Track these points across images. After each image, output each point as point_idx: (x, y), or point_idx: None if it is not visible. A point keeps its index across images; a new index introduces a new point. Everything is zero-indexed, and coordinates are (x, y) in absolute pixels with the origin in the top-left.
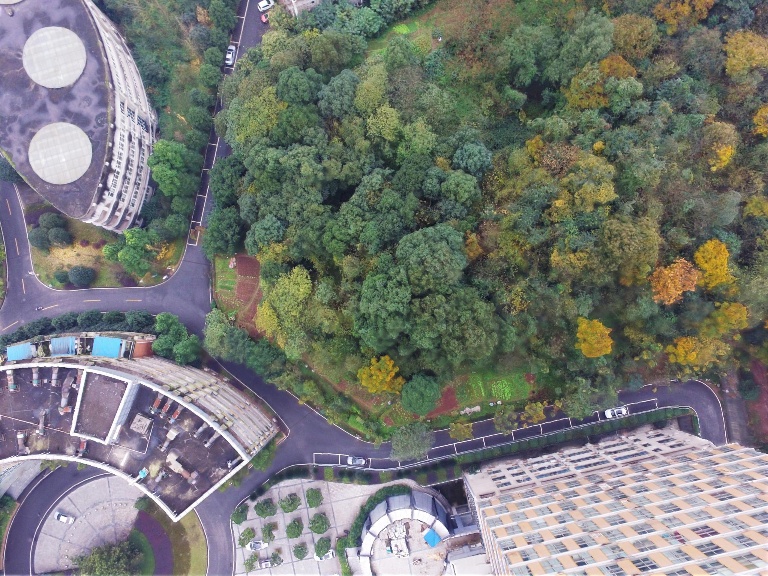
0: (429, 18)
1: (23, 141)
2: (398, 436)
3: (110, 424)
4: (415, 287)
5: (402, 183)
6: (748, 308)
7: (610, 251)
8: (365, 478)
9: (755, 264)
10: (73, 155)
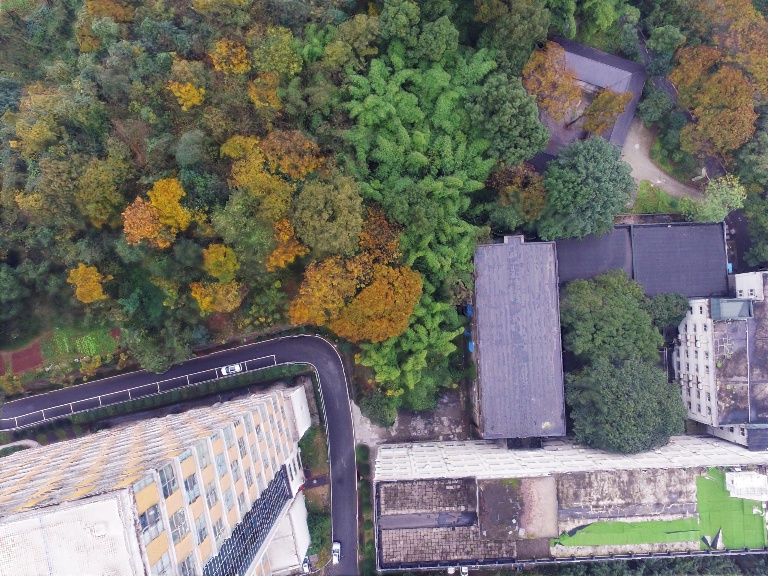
0: None
1: None
2: None
3: None
4: None
5: None
6: (241, 250)
7: None
8: None
9: None
10: None
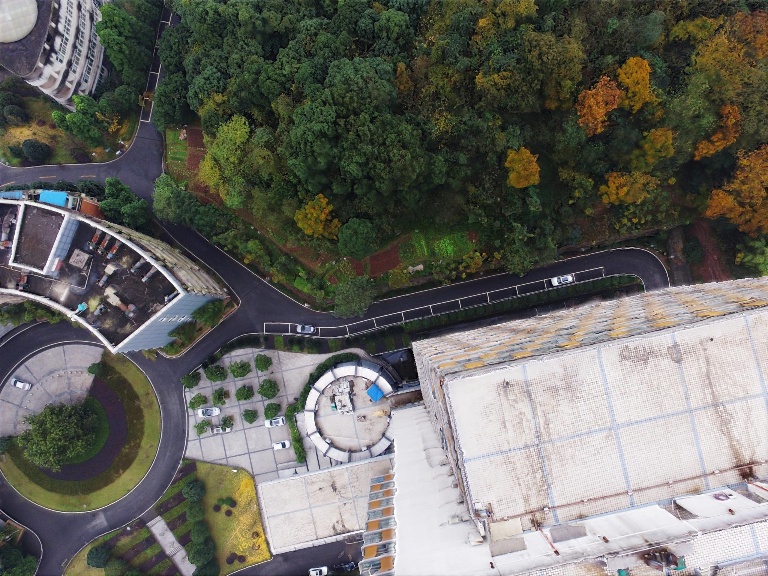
0: None
1: None
2: (339, 289)
3: (48, 255)
4: (340, 107)
5: (337, 26)
6: (676, 137)
7: (531, 66)
8: (314, 345)
9: (681, 88)
10: (19, 14)
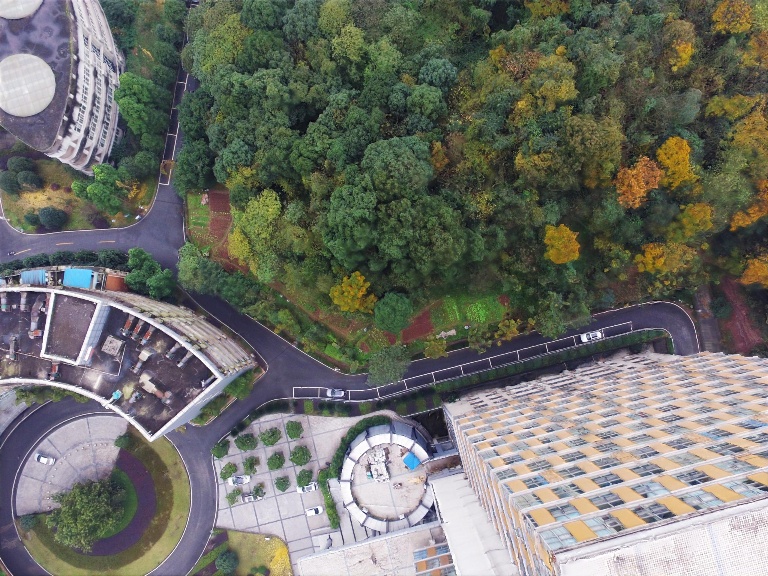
0: None
1: None
2: (374, 359)
3: (80, 345)
4: (380, 192)
5: (368, 100)
6: (713, 210)
7: (573, 149)
8: (345, 409)
9: (718, 163)
10: (36, 87)
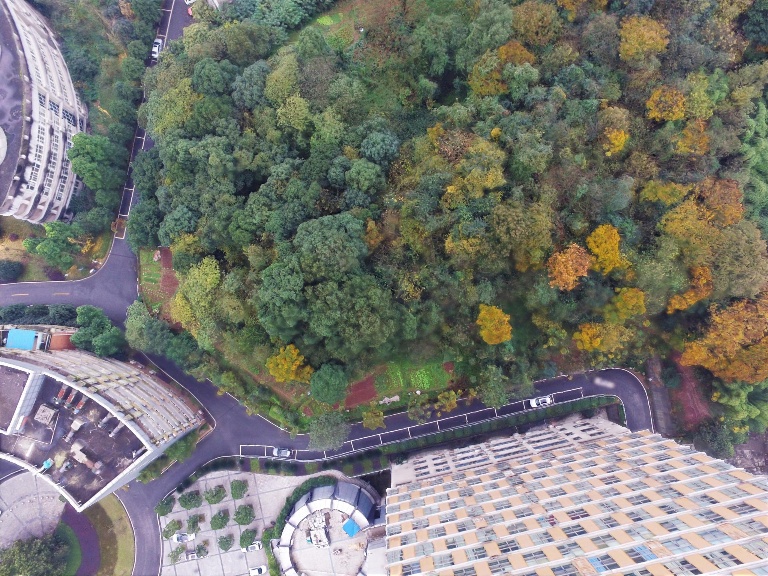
0: (352, 9)
1: None
2: (314, 426)
3: (12, 415)
4: (308, 274)
5: (308, 172)
6: (648, 293)
7: (500, 236)
8: (290, 469)
9: (651, 249)
10: None
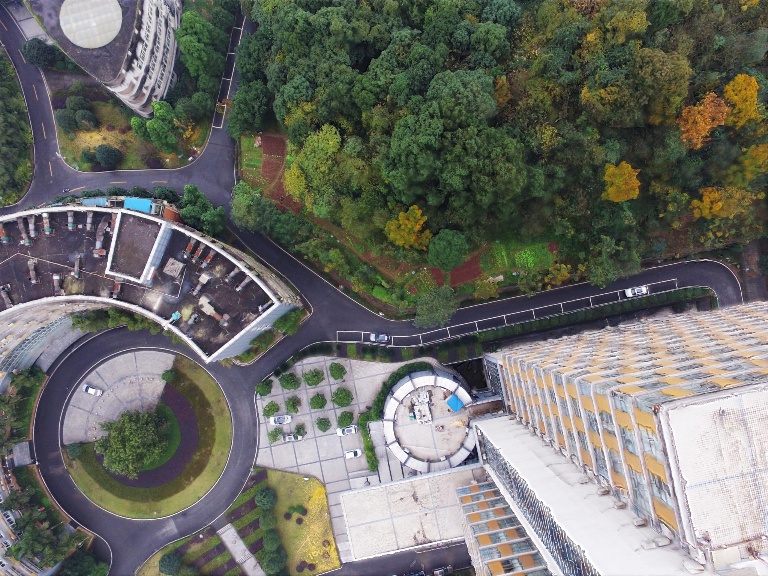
0: None
1: (54, 5)
2: (423, 299)
3: (144, 263)
4: (447, 120)
5: (431, 37)
6: None
7: (641, 82)
8: (387, 354)
9: None
10: (103, 20)
